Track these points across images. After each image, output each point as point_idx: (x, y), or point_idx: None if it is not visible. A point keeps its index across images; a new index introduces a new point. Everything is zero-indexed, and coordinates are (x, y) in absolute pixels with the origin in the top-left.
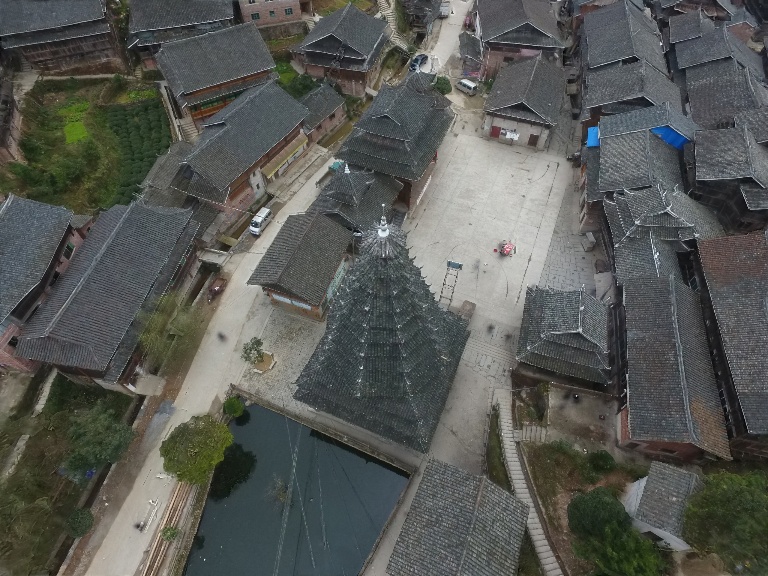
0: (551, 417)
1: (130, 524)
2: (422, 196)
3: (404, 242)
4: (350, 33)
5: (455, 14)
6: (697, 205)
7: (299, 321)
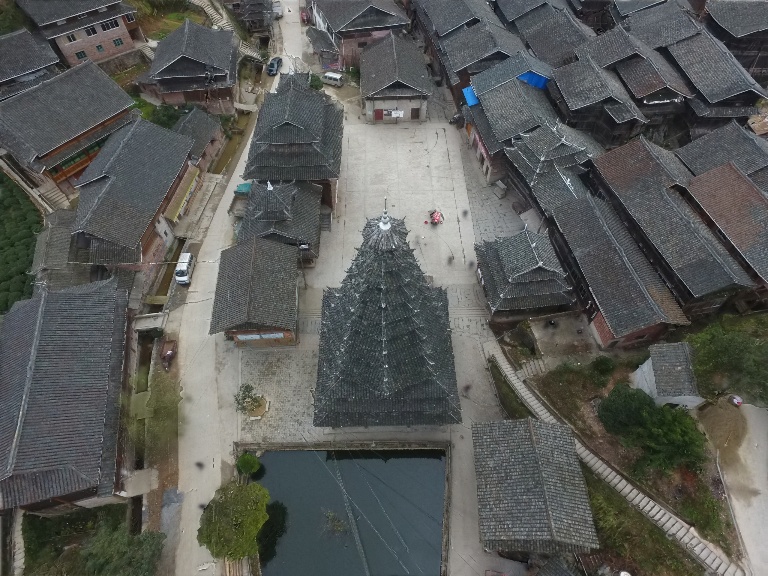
0: (541, 348)
1: None
2: (337, 193)
3: (405, 229)
4: (201, 51)
5: (288, 12)
6: (576, 131)
7: (274, 353)
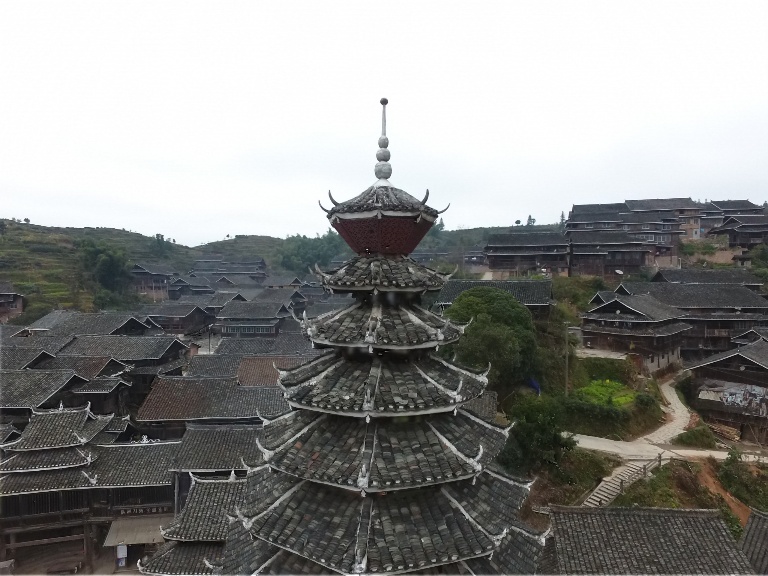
0: None
1: None
2: None
3: None
4: None
5: None
6: None
7: None
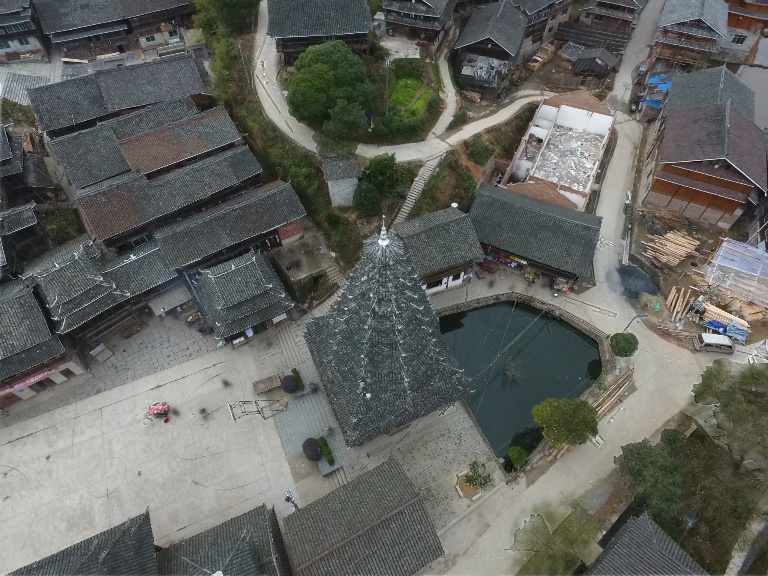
0: None
1: (631, 430)
2: None
3: (373, 237)
4: None
5: None
6: None
7: None
